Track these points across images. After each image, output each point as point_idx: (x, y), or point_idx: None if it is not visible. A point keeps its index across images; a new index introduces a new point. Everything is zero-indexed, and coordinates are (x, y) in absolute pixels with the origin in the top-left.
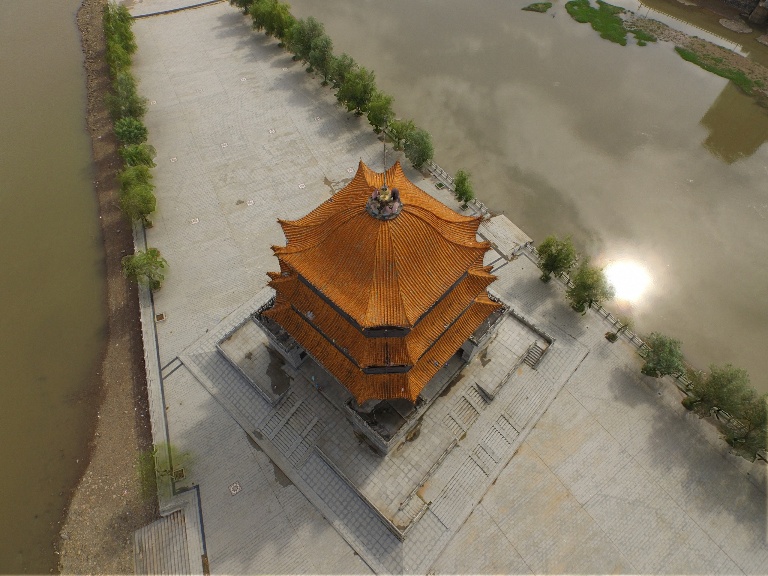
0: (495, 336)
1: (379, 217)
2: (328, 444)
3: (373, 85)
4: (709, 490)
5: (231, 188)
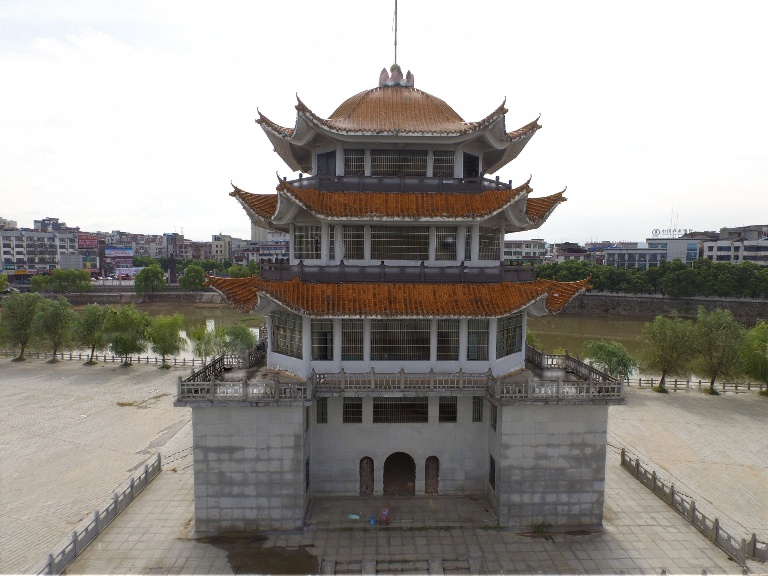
0: None
1: (405, 86)
2: None
3: (147, 321)
4: (766, 415)
5: None
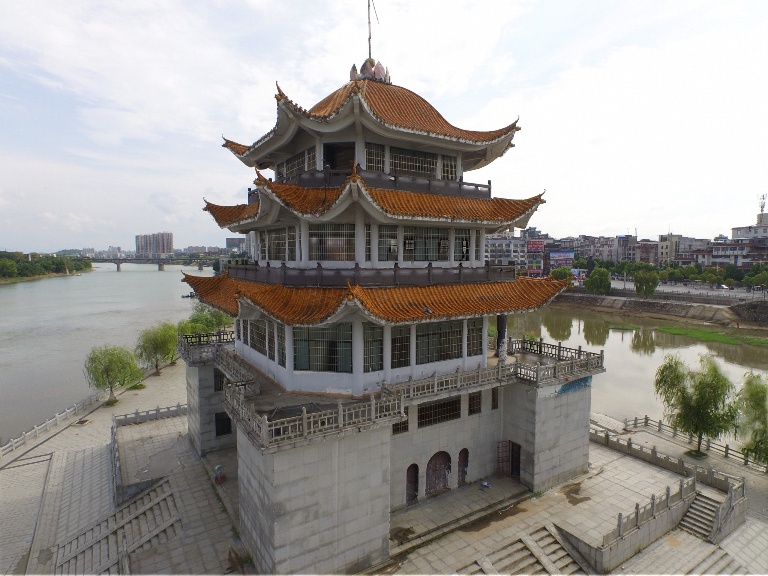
0: (597, 472)
1: None
2: (156, 559)
3: None
4: None
5: None
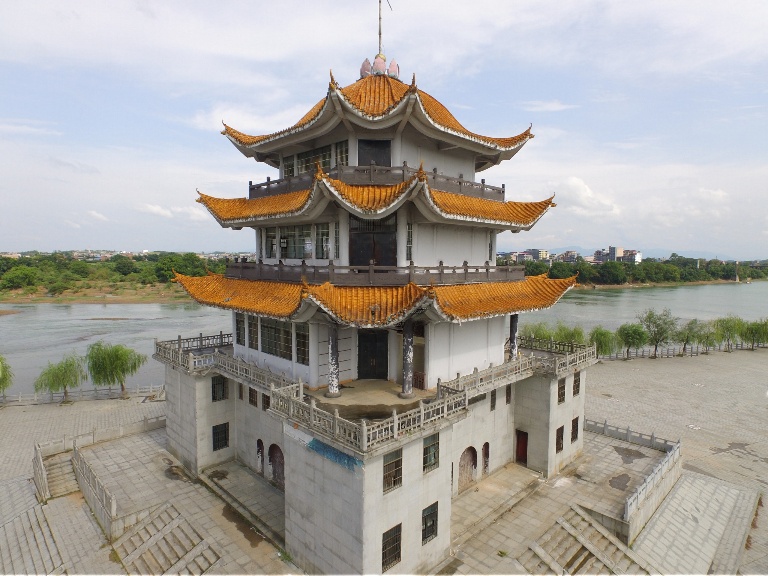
0: None
1: None
2: None
3: None
4: None
5: (627, 391)
